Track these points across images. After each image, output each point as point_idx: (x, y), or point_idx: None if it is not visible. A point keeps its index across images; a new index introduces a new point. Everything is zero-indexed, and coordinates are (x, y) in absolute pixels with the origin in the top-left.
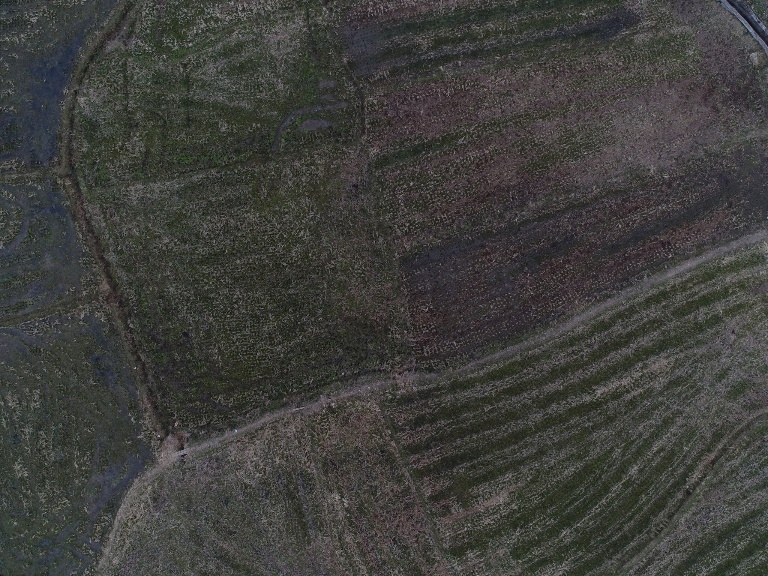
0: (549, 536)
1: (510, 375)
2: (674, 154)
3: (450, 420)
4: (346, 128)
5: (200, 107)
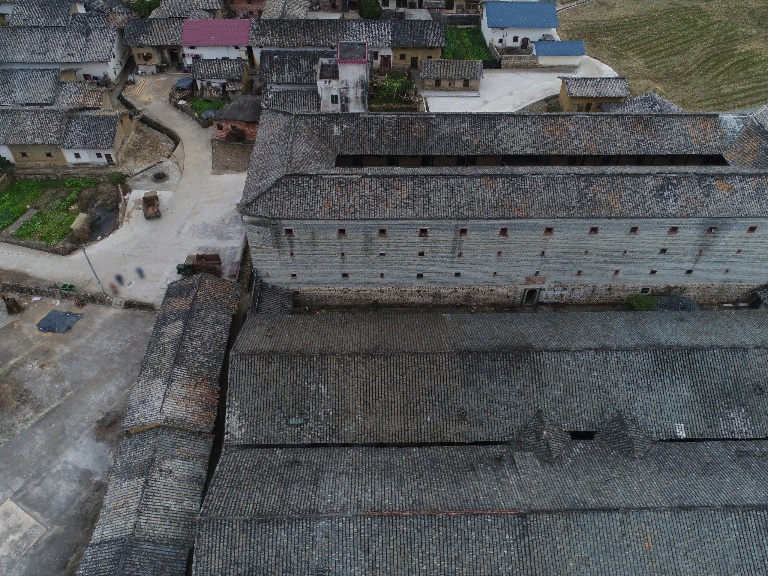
0: None
1: None
2: None
3: None
4: None
5: None
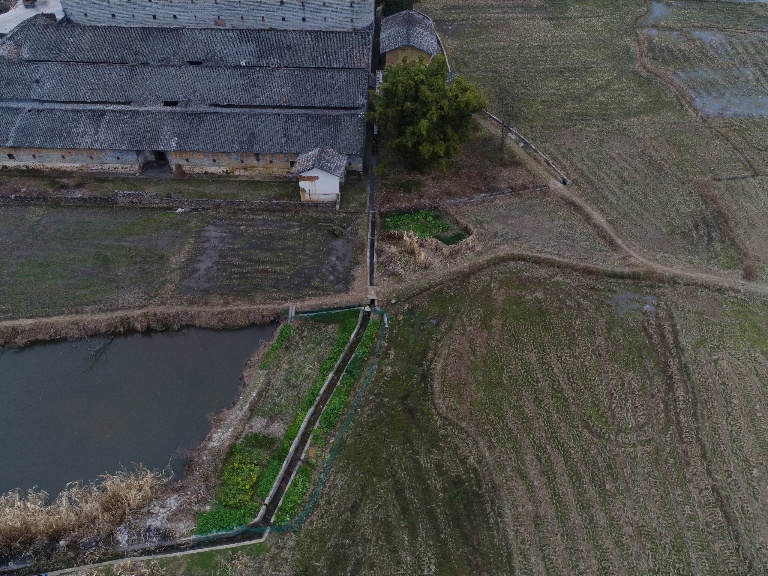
0: None
1: None
2: None
3: None
4: None
5: (601, 6)
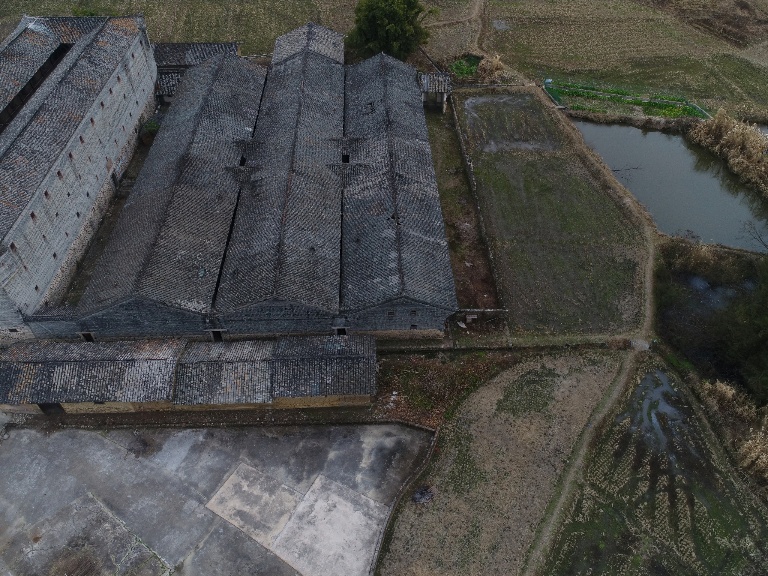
0: None
1: None
2: None
3: None
4: None
5: None
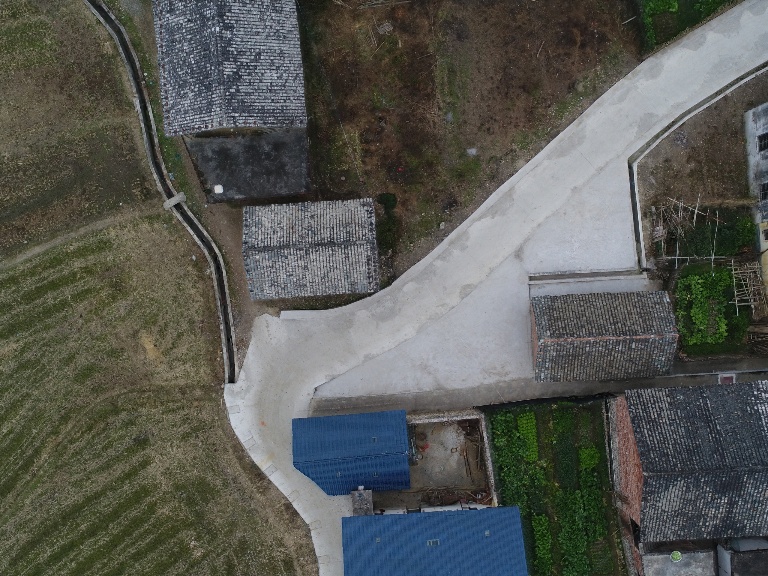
0: None
1: None
2: (29, 141)
3: None
4: None
5: None
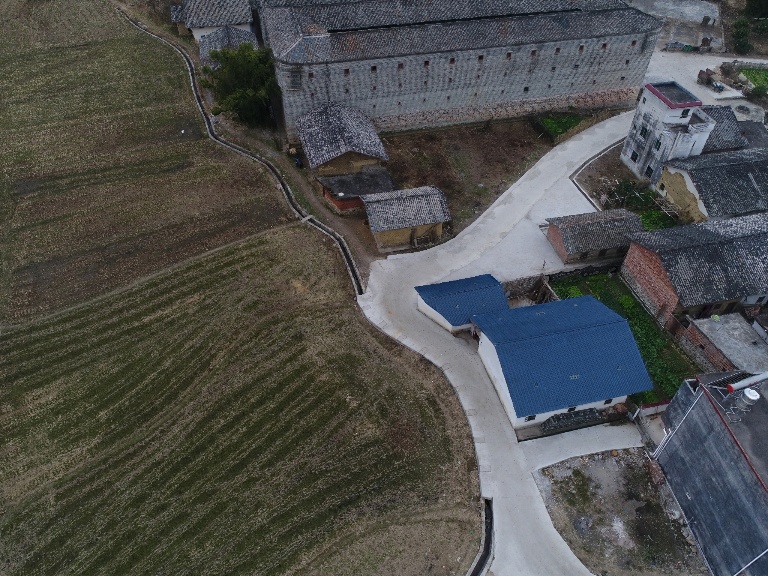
0: (87, 418)
1: (78, 318)
2: (212, 207)
3: (22, 350)
4: (1, 218)
5: None
